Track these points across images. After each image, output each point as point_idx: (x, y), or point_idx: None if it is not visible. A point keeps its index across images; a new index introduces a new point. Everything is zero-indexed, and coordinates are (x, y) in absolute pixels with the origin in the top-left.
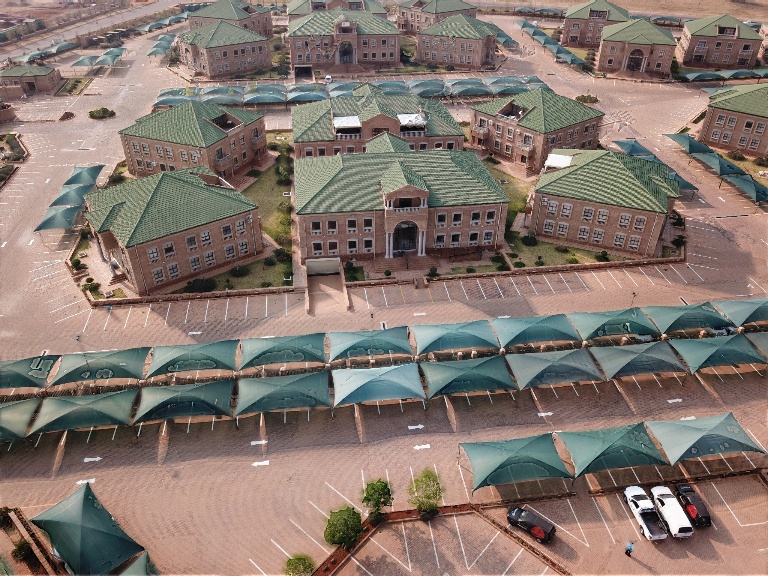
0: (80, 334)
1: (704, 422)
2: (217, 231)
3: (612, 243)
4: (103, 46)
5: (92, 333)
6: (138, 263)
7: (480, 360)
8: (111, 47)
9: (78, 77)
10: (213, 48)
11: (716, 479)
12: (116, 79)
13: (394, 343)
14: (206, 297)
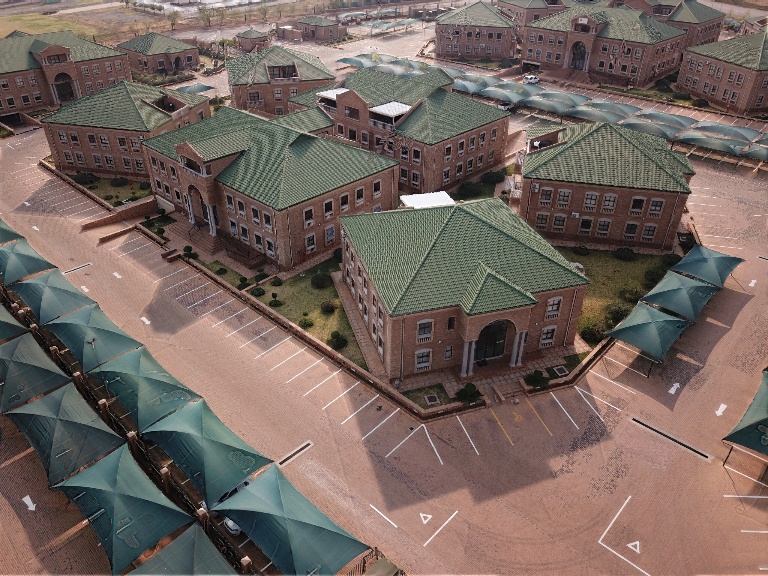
0: (5, 174)
1: None
2: (115, 139)
3: None
4: (421, 18)
5: (8, 177)
6: (52, 139)
7: (4, 318)
8: (425, 20)
9: (359, 36)
10: (446, 25)
11: None
12: (377, 42)
13: (9, 266)
14: (77, 188)
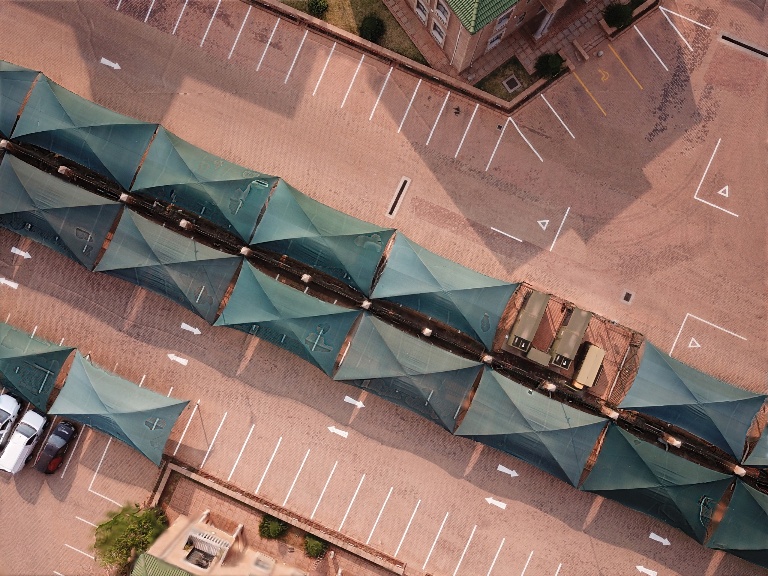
0: None
1: (127, 397)
2: None
3: (414, 6)
4: None
5: None
6: None
7: None
8: None
9: None
10: None
11: (117, 439)
12: None
13: None
14: None
